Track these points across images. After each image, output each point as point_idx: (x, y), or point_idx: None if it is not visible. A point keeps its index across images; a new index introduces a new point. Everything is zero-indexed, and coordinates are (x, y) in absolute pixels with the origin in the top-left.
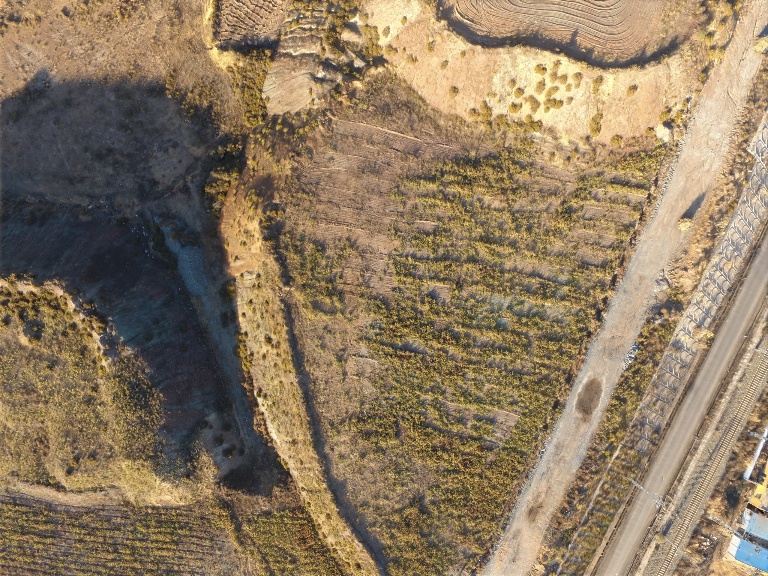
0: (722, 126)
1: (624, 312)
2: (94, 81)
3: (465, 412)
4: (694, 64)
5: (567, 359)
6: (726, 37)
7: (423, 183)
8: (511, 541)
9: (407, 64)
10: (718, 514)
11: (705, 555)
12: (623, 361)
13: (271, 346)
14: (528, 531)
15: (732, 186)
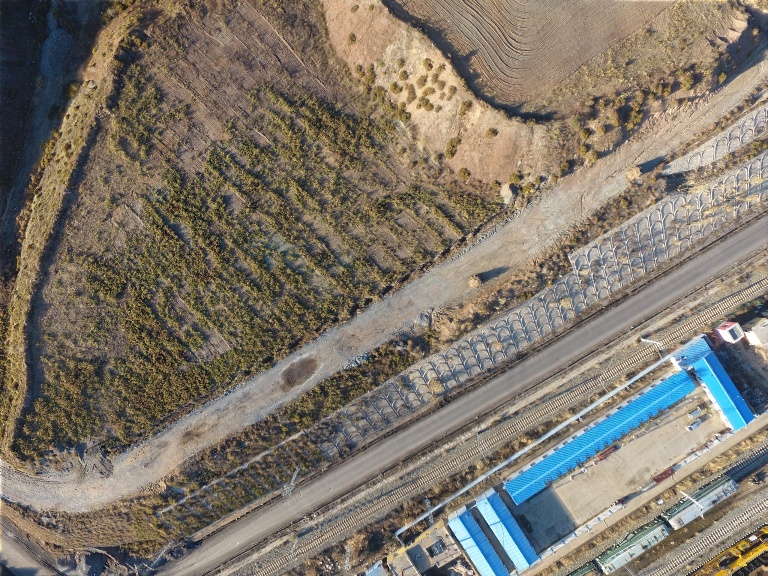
0: (559, 221)
1: (376, 321)
2: None
3: (188, 315)
4: (559, 147)
5: (302, 328)
6: (605, 145)
7: (281, 101)
8: (154, 448)
9: None
10: (353, 548)
11: (321, 575)
12: (348, 361)
13: (66, 153)
14: (174, 449)
15: (535, 276)
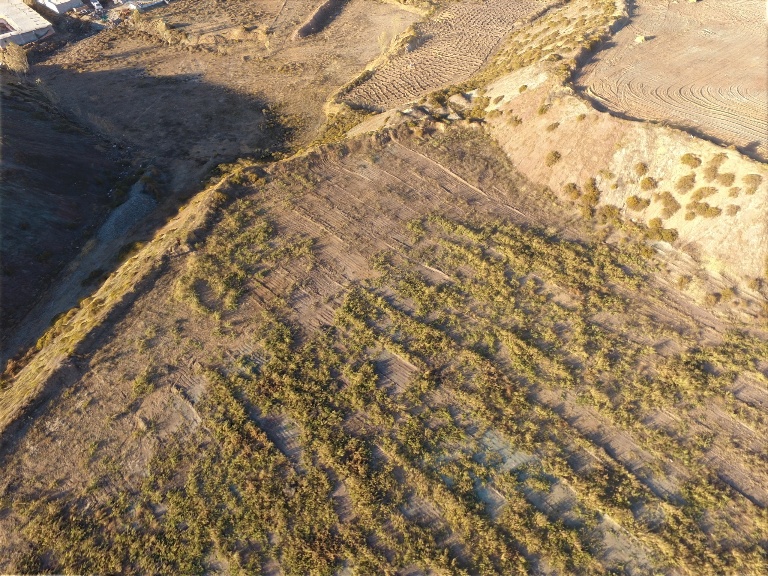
0: None
1: None
2: (220, 88)
3: None
4: None
5: None
6: None
7: (461, 229)
8: None
9: (507, 126)
10: None
11: None
12: None
13: None
14: None
15: None
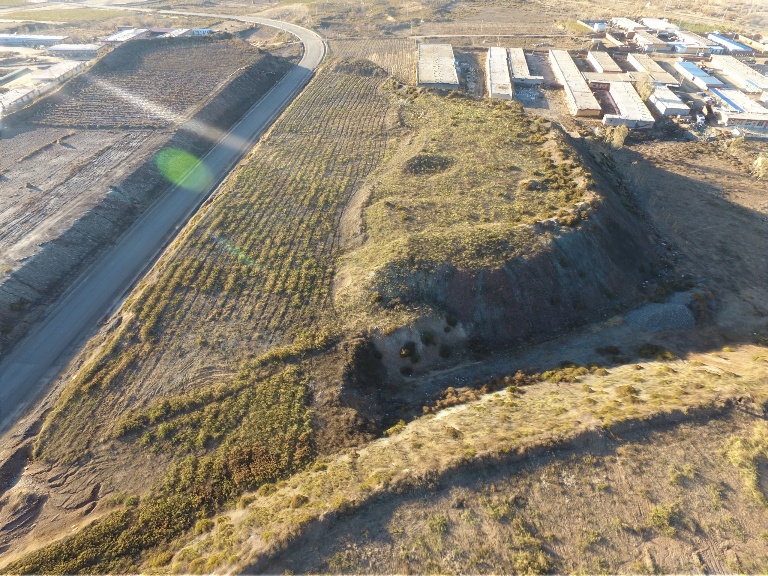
0: None
1: None
2: None
3: None
4: None
5: None
6: None
7: None
8: None
9: None
10: None
11: None
12: None
13: (626, 393)
14: None
15: None
